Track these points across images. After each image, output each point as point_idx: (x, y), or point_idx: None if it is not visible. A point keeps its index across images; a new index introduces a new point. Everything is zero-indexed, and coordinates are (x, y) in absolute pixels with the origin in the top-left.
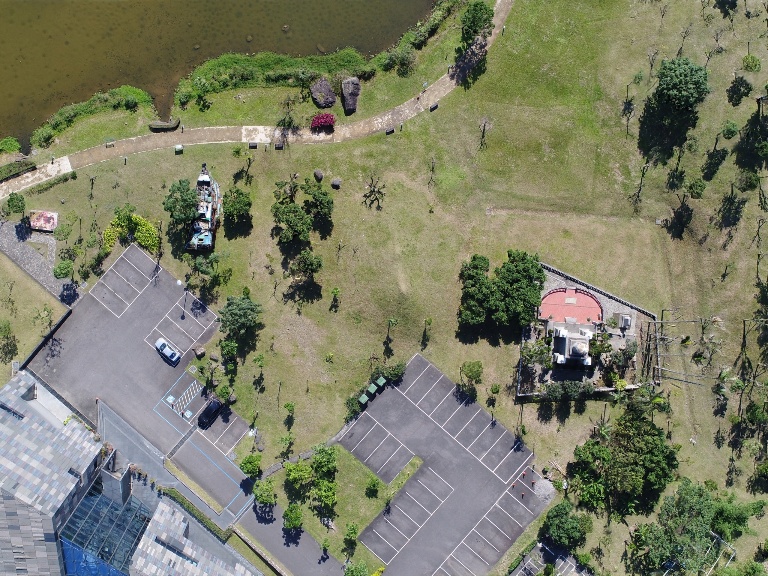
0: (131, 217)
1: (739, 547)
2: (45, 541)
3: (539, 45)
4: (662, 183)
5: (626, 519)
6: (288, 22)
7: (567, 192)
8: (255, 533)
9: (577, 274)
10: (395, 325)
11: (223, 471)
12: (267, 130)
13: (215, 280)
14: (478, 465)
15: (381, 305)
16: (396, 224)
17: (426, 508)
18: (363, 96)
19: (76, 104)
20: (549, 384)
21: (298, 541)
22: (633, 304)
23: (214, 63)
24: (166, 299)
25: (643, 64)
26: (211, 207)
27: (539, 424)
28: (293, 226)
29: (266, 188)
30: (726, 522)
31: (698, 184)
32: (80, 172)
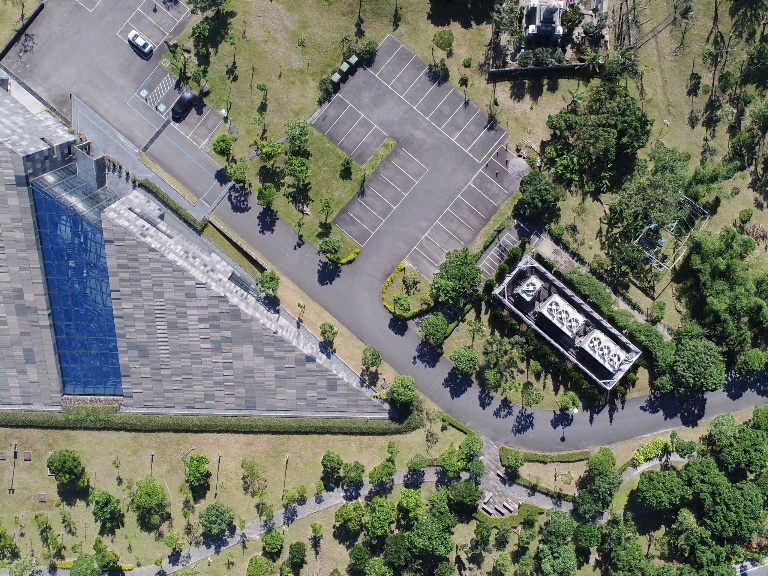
0: None
1: (714, 225)
2: (16, 185)
3: None
4: None
5: (601, 197)
6: None
7: None
8: (230, 222)
9: None
10: None
11: (198, 163)
12: None
13: None
14: (452, 145)
15: None
16: None
17: (400, 189)
18: None
19: None
20: None
21: (273, 228)
22: None
23: None
24: None
25: None
26: None
27: (512, 103)
28: None
29: None
30: (699, 184)
31: None
32: None
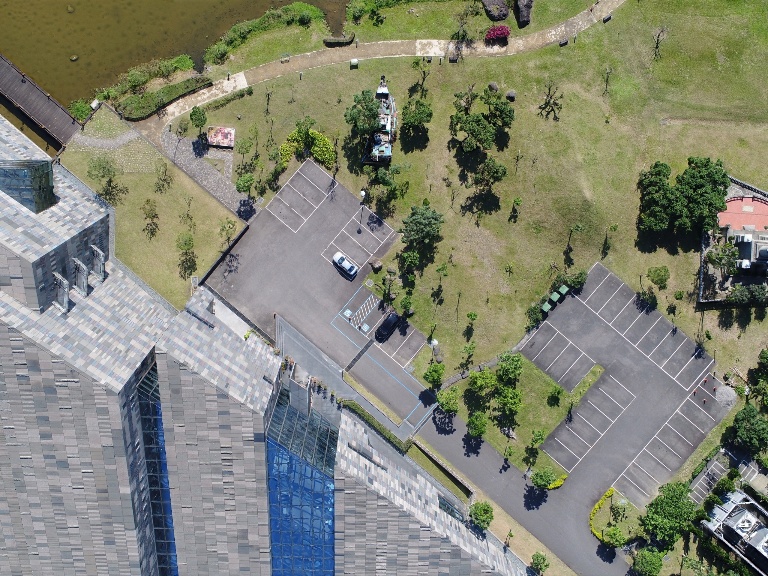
0: (308, 132)
1: None
2: (254, 441)
3: None
4: None
5: None
6: None
7: (742, 101)
8: (435, 444)
9: (753, 182)
10: None
11: (401, 383)
12: (441, 43)
13: (392, 194)
14: (659, 372)
15: (563, 214)
16: (575, 134)
17: (608, 416)
18: (536, 8)
19: (249, 21)
20: (730, 290)
21: (478, 451)
22: None
23: None
24: (342, 213)
25: None
26: (390, 119)
27: (720, 331)
28: (477, 135)
29: (441, 101)
30: None
31: None
32: (256, 88)
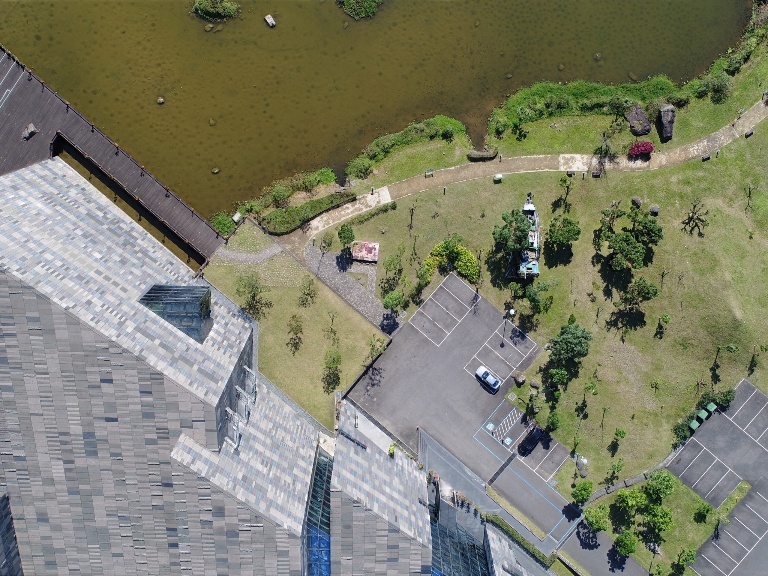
0: None
1: None
2: (421, 573)
3: None
4: None
5: None
6: (599, 50)
7: None
8: (579, 559)
9: None
10: (735, 352)
11: (544, 497)
12: (584, 158)
13: (535, 308)
14: None
15: (711, 332)
16: (721, 251)
17: (755, 532)
18: (678, 123)
19: (391, 134)
20: None
21: (623, 566)
22: None
23: (528, 92)
24: (485, 327)
25: None
26: None
27: None
28: (627, 254)
29: (584, 216)
30: None
31: None
32: (399, 202)
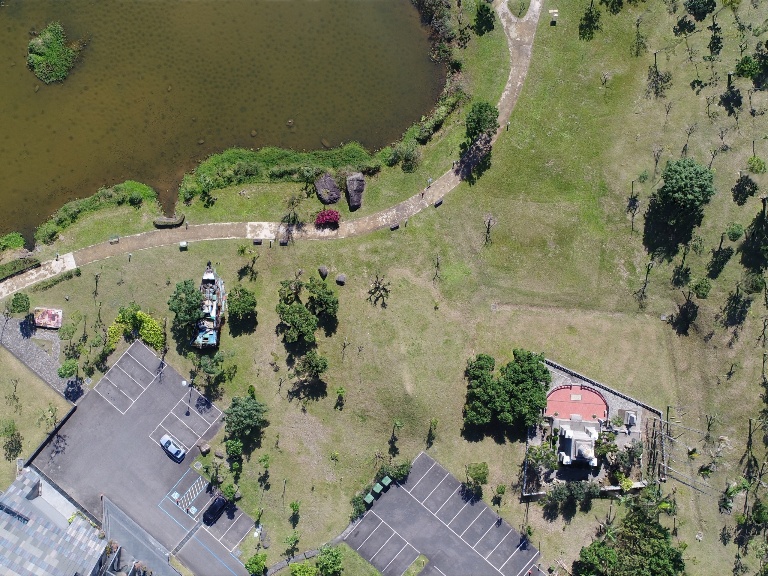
0: (136, 314)
1: None
2: None
3: (544, 140)
4: (667, 280)
5: None
6: (292, 117)
7: (572, 288)
8: None
9: (582, 370)
10: None
11: (228, 568)
12: (272, 226)
13: (220, 377)
14: (484, 564)
15: (386, 405)
16: (401, 322)
17: None
18: (368, 192)
19: (80, 199)
20: (555, 483)
21: None
22: (638, 401)
23: (218, 158)
24: (171, 395)
25: (648, 160)
26: (216, 305)
27: (545, 522)
28: (298, 327)
29: (271, 284)
30: None
31: (704, 285)
32: (84, 269)
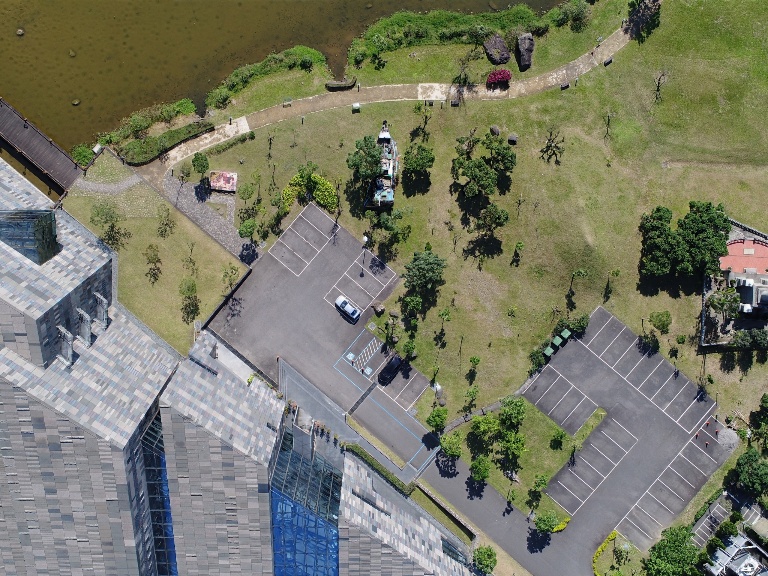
0: (310, 176)
1: None
2: (258, 492)
3: None
4: None
5: None
6: None
7: (743, 144)
8: (438, 487)
9: (754, 225)
10: (585, 276)
11: (404, 426)
12: (443, 87)
13: (394, 237)
14: (661, 415)
15: (565, 258)
16: (577, 178)
17: (610, 459)
18: (537, 52)
19: (251, 65)
20: (732, 334)
21: (482, 494)
22: None
23: (387, 22)
24: (345, 257)
25: None
26: (392, 164)
27: (722, 374)
28: (479, 180)
29: (443, 145)
30: None
31: None
32: (258, 132)
